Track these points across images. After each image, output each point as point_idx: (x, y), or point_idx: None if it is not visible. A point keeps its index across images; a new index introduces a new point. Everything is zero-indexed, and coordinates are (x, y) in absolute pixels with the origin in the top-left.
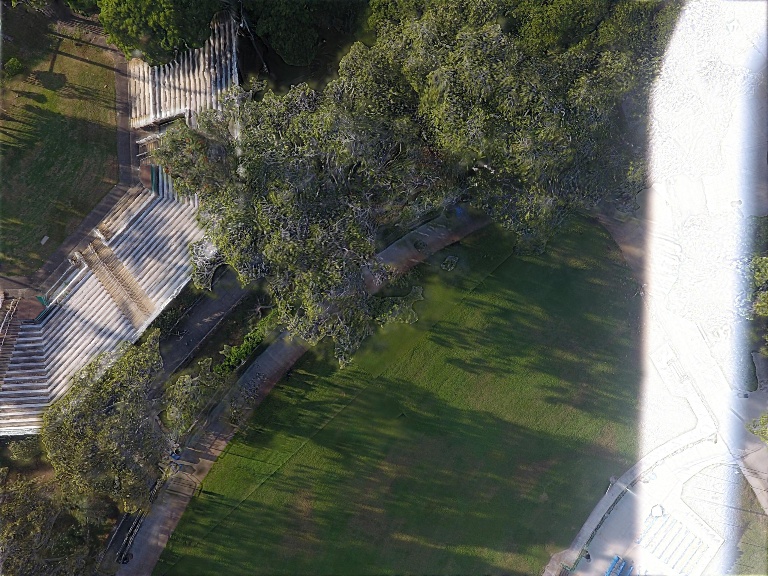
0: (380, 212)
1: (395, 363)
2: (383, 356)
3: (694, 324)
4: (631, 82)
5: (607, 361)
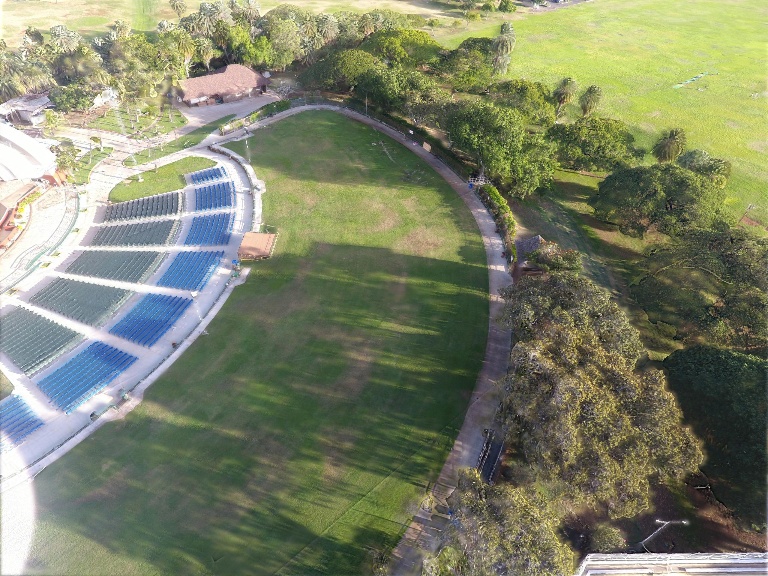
0: None
1: None
2: None
3: None
4: None
5: None
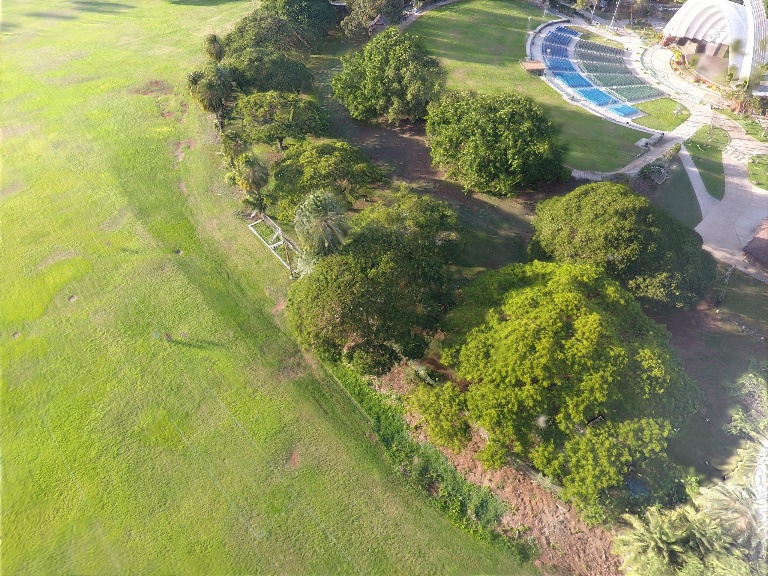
0: None
1: (471, 6)
2: (468, 5)
3: None
4: None
5: None
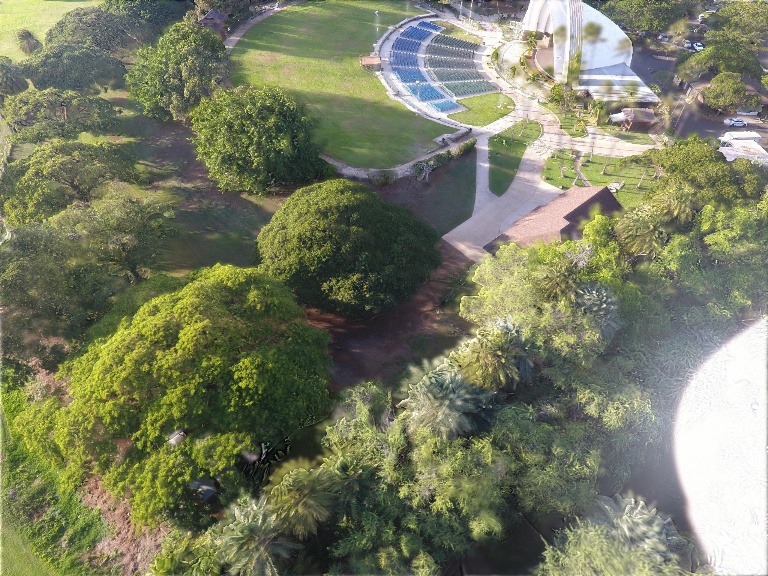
0: None
1: (340, 1)
2: None
3: (426, 4)
4: None
5: None
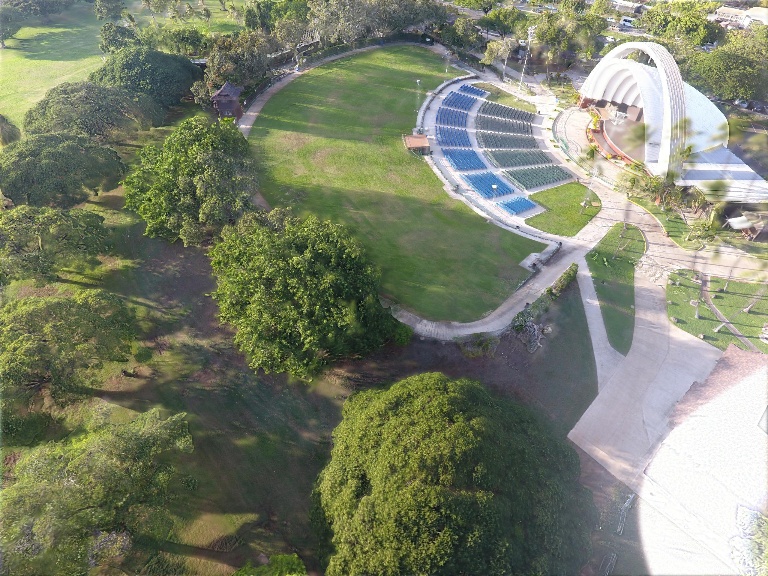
0: (358, 1)
1: (367, 61)
2: None
3: None
4: (413, 0)
5: (435, 64)
